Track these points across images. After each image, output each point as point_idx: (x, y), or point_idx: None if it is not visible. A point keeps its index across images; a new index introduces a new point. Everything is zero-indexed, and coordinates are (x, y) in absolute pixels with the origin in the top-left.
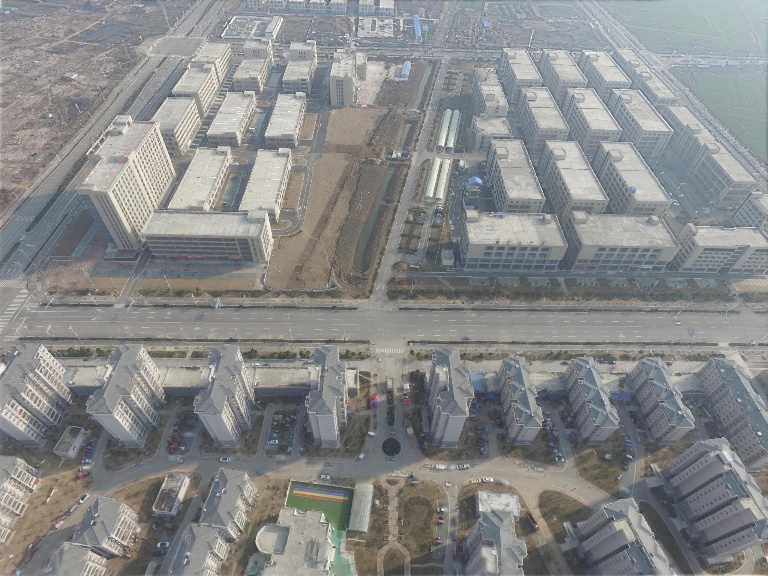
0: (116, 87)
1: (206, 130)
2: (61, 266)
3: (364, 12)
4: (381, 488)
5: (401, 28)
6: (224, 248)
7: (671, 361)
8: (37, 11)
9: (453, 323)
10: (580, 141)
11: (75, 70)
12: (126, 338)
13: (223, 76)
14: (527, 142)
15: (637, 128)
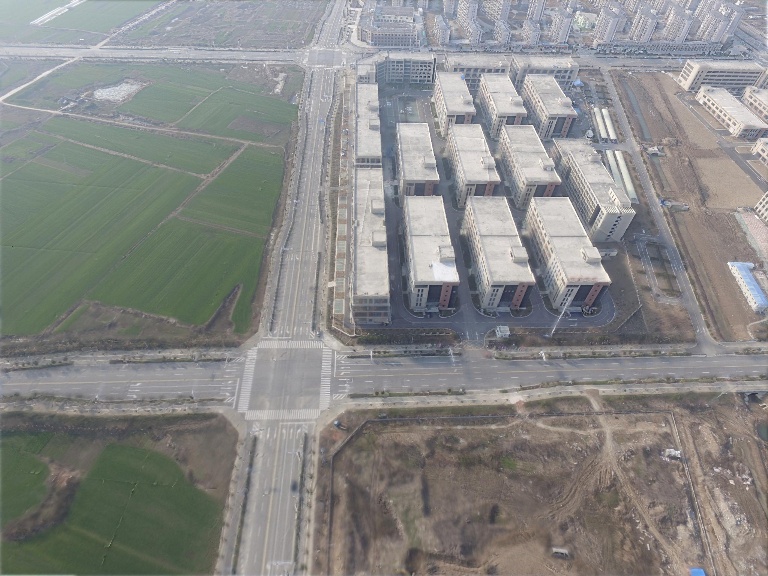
0: None
1: None
2: None
3: None
4: (571, 31)
5: None
6: None
7: (456, 50)
8: None
9: None
10: None
11: None
12: None
13: None
14: None
15: None
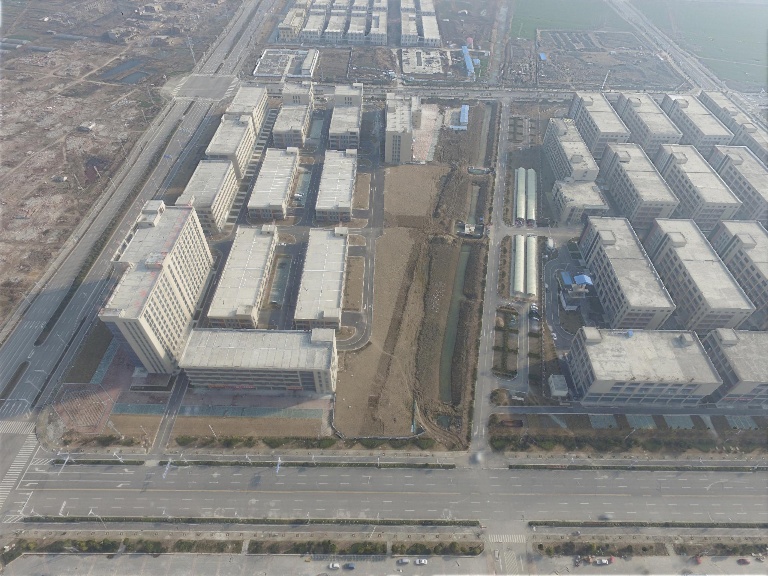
0: (139, 140)
1: (244, 197)
2: (78, 399)
3: (407, 43)
4: None
5: (450, 62)
6: (282, 379)
7: None
8: (51, 44)
9: (582, 491)
10: (685, 212)
11: (93, 118)
12: (162, 518)
13: (260, 126)
14: (620, 211)
15: (757, 199)
